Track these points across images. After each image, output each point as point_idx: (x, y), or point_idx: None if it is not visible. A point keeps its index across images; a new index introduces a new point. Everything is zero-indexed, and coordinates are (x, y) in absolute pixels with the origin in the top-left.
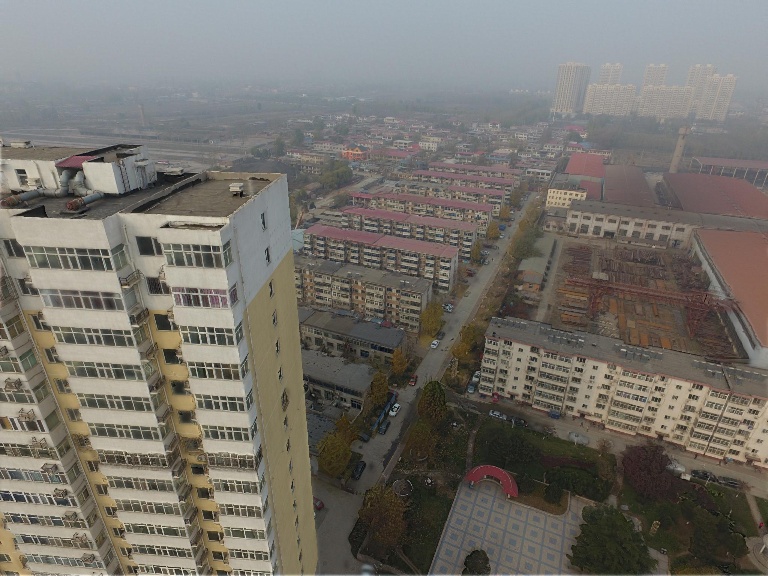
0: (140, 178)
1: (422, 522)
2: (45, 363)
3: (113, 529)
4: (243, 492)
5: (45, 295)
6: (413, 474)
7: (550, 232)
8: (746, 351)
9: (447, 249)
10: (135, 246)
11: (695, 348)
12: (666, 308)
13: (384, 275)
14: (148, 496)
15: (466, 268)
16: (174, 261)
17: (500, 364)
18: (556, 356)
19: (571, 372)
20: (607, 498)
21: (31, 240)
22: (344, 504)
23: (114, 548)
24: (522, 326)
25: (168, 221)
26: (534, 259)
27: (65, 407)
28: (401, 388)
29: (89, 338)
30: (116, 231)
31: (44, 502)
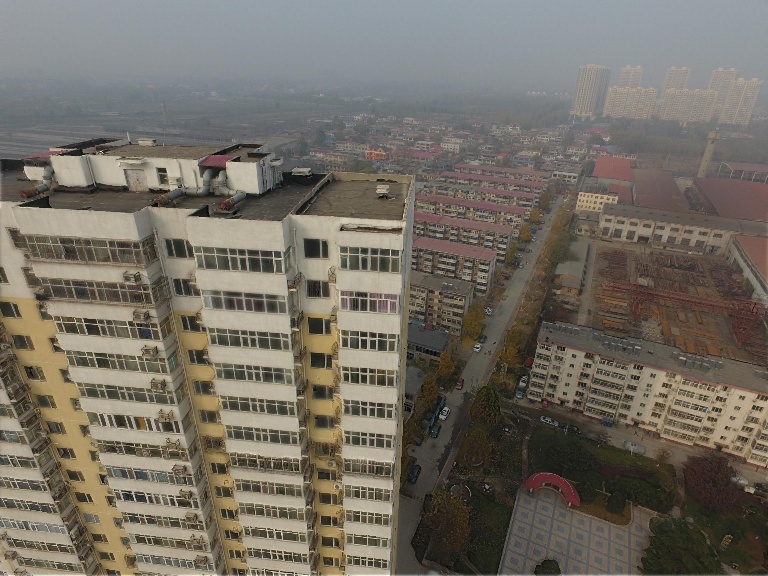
0: (272, 178)
1: (484, 529)
2: (186, 364)
3: (225, 531)
4: (374, 499)
5: (207, 296)
6: (469, 479)
7: (582, 236)
8: None
9: (485, 252)
10: (302, 248)
11: (744, 357)
12: (709, 316)
13: (425, 277)
14: (274, 500)
15: (501, 271)
16: (348, 264)
17: (551, 370)
18: (612, 363)
19: (627, 379)
20: (671, 509)
21: (203, 241)
22: (403, 508)
23: (223, 550)
24: (574, 331)
25: (342, 223)
26: (570, 263)
27: (199, 408)
28: (448, 391)
29: (243, 340)
30: (287, 233)
31: (165, 503)
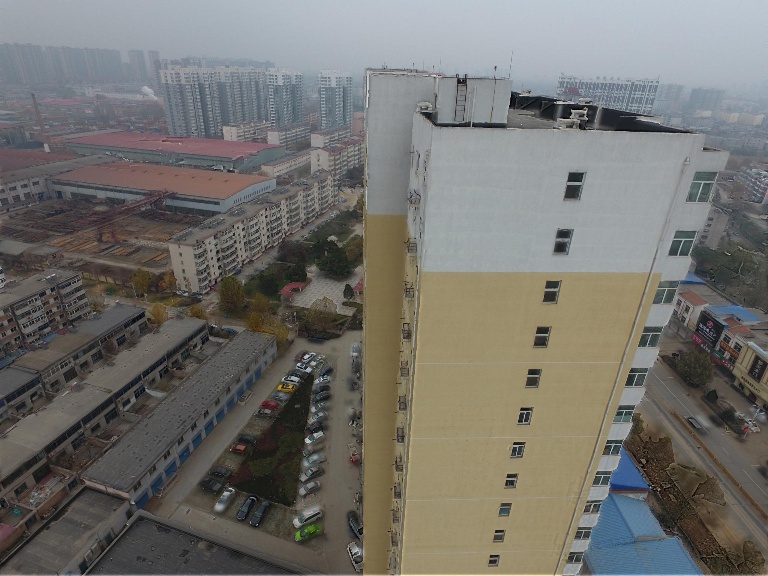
0: None
1: None
2: None
3: None
4: None
5: None
6: None
7: None
8: (212, 210)
9: None
10: None
11: None
12: (137, 223)
13: (6, 292)
14: None
15: None
16: None
17: None
18: None
19: None
20: None
21: None
22: (302, 345)
23: None
24: (191, 232)
25: None
26: (4, 243)
27: None
28: None
29: None
30: None
31: None
